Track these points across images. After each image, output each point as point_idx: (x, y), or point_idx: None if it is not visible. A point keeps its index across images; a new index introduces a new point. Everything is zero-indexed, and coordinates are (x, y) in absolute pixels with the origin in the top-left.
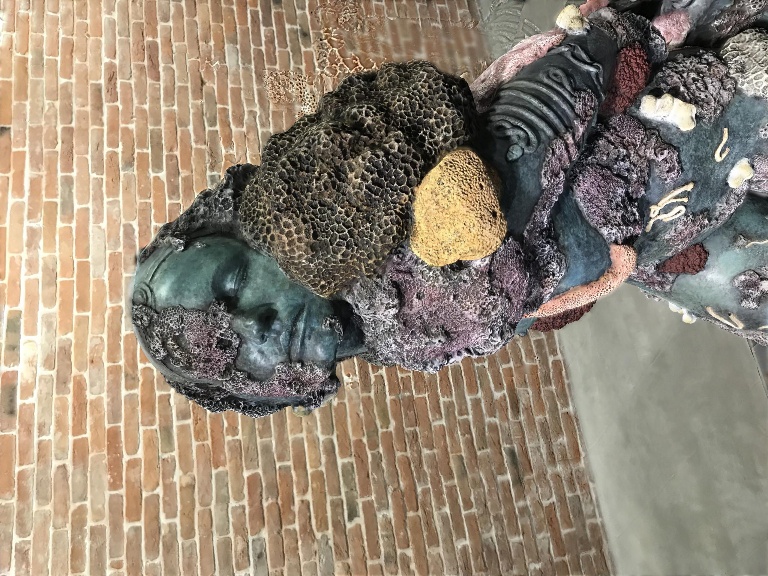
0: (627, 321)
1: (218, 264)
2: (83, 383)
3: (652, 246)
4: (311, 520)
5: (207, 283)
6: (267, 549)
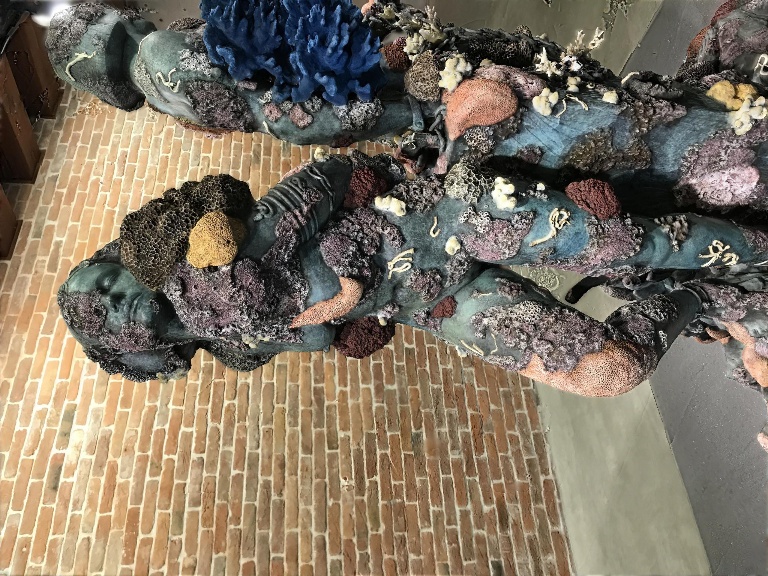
0: (599, 436)
1: (102, 272)
2: (115, 468)
3: (403, 292)
4: None
5: (94, 280)
6: None
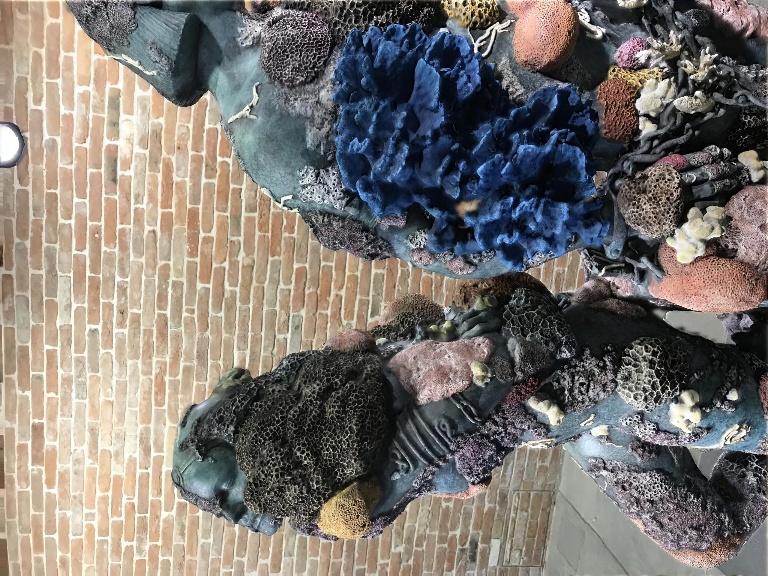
0: None
1: (219, 478)
2: (170, 166)
3: None
4: (341, 310)
5: (211, 488)
6: (303, 324)
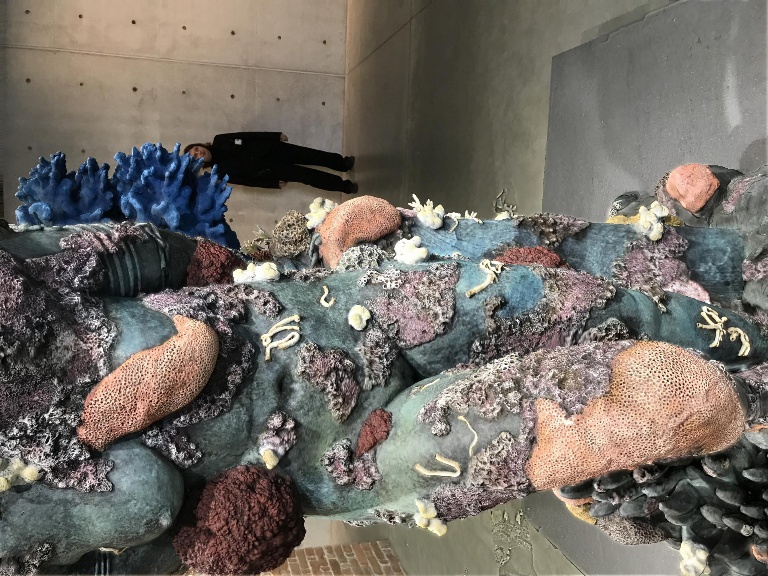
0: None
1: None
2: None
3: (296, 390)
4: None
5: None
6: None
